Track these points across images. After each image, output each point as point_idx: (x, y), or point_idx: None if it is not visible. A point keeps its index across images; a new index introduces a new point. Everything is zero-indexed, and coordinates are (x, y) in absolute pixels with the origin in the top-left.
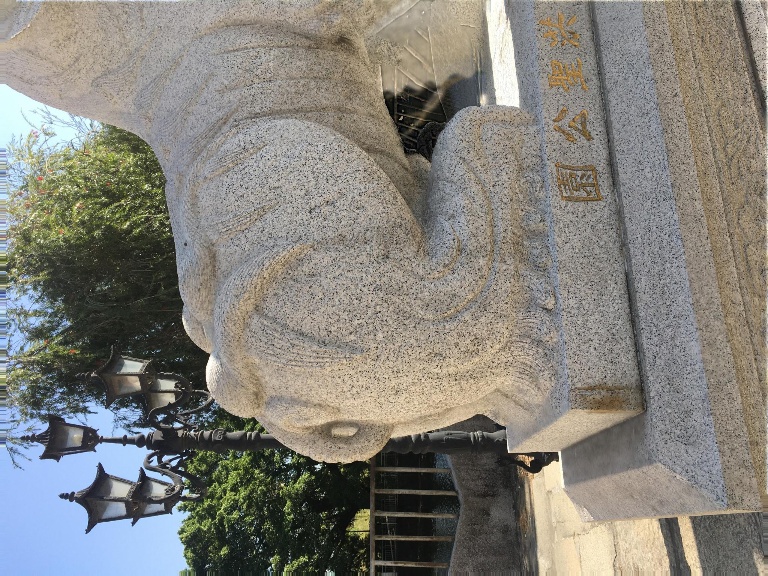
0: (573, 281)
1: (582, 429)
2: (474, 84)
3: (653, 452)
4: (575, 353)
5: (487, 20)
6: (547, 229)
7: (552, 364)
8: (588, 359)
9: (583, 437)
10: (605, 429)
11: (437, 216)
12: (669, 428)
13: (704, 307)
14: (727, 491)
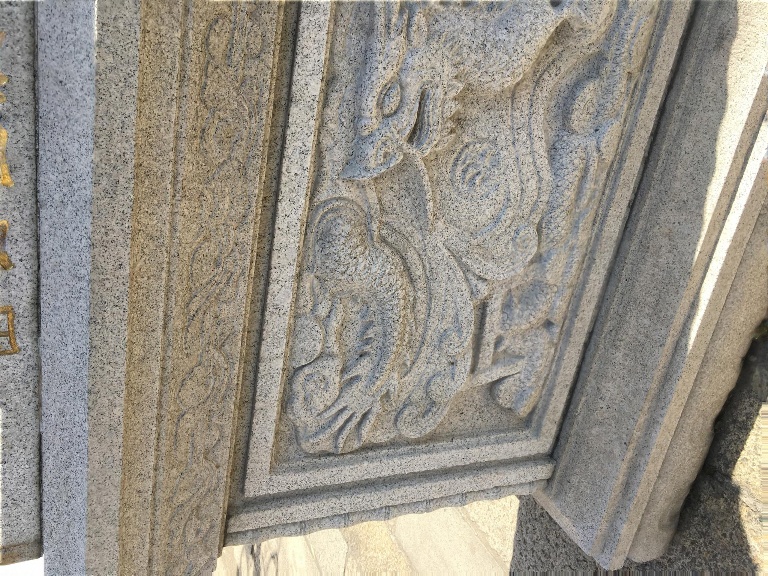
0: None
1: None
2: None
3: None
4: None
5: None
6: None
7: None
8: None
9: None
10: None
11: None
12: None
13: (98, 515)
14: None
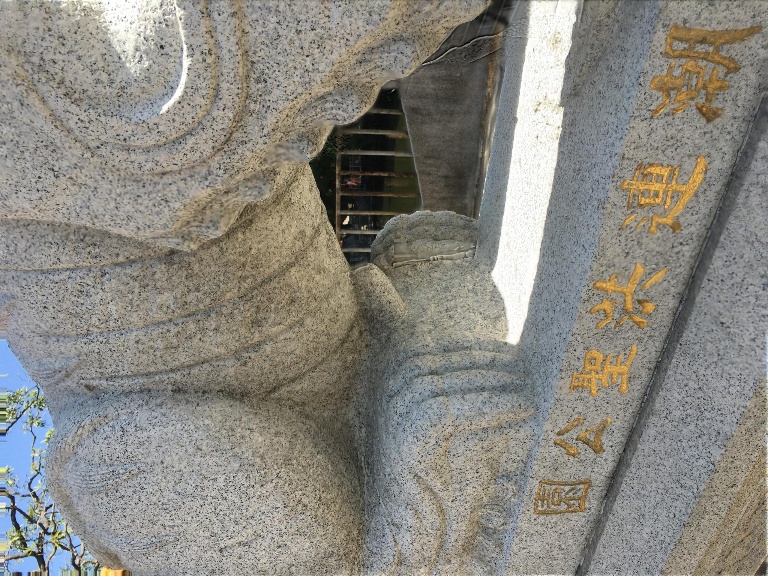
0: (519, 575)
1: None
2: (480, 129)
3: None
4: None
5: None
6: None
7: None
8: None
9: None
10: None
11: (379, 504)
12: None
13: None
14: None
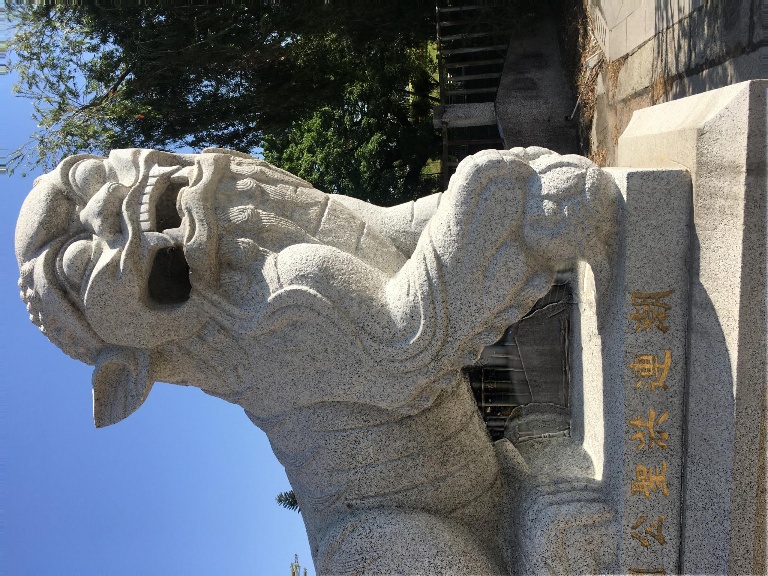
0: None
1: None
2: (561, 353)
3: None
4: None
5: None
6: None
7: None
8: None
9: None
10: None
11: None
12: None
13: None
14: None
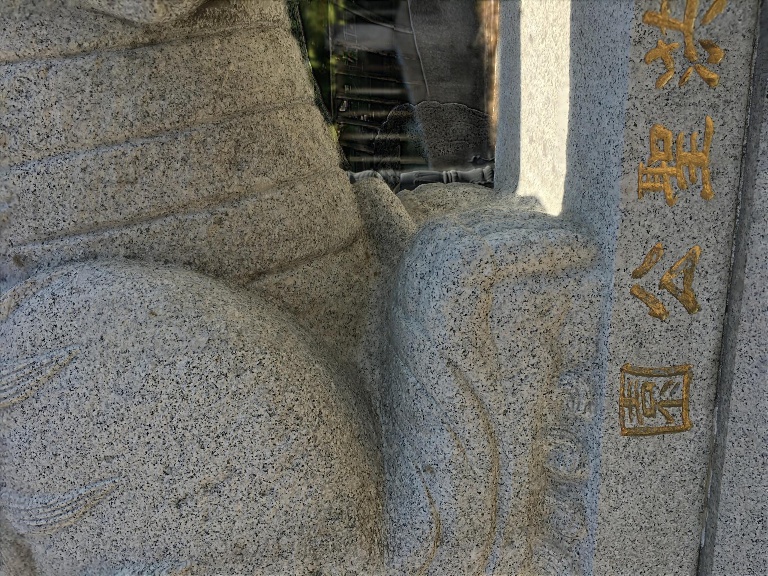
0: (615, 569)
1: None
2: (482, 2)
3: None
4: None
5: None
6: (587, 476)
7: None
8: None
9: None
10: None
11: (404, 445)
12: None
13: None
14: None
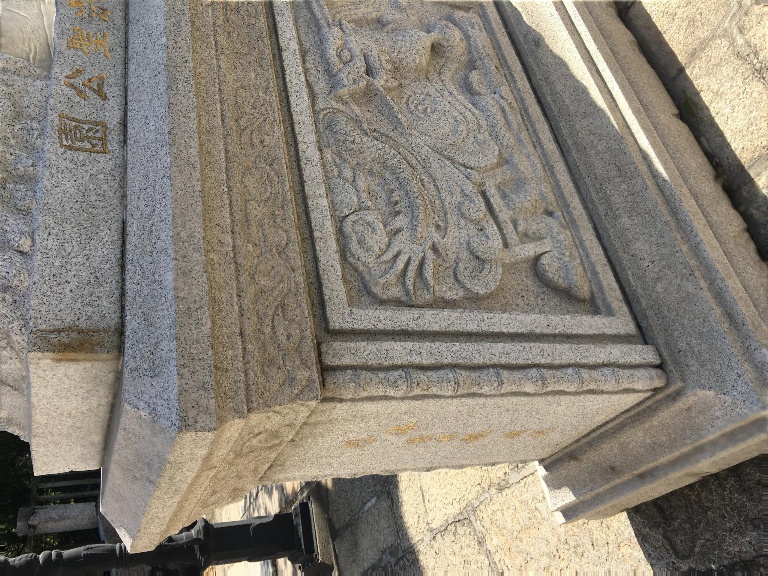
0: (57, 224)
1: (83, 406)
2: None
3: (123, 395)
4: (44, 294)
5: (43, 13)
6: (38, 174)
7: (22, 312)
8: (60, 300)
9: (103, 430)
10: (112, 406)
11: None
12: (138, 364)
13: (184, 239)
14: (180, 413)
